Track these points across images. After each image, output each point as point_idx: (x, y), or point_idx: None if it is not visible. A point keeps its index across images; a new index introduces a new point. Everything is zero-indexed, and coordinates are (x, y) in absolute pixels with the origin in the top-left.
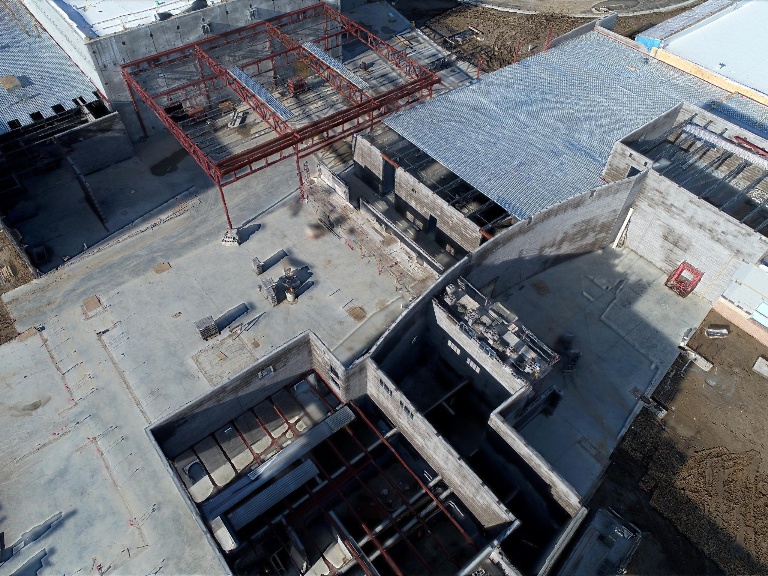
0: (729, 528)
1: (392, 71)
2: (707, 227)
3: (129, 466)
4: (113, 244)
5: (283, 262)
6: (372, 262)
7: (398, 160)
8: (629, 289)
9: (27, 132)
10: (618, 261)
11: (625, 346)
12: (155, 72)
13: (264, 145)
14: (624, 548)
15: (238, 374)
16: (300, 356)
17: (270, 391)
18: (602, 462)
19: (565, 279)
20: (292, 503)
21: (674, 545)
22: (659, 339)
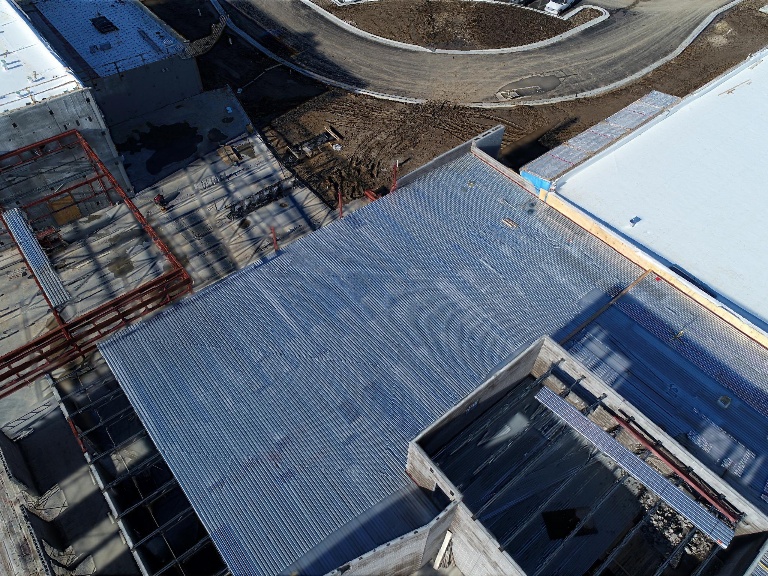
0: None
1: (199, 207)
2: None
3: None
4: None
5: None
6: None
7: None
8: None
9: None
10: None
11: None
12: None
13: None
14: None
15: None
16: None
17: None
18: None
19: None
20: None
21: None
22: None
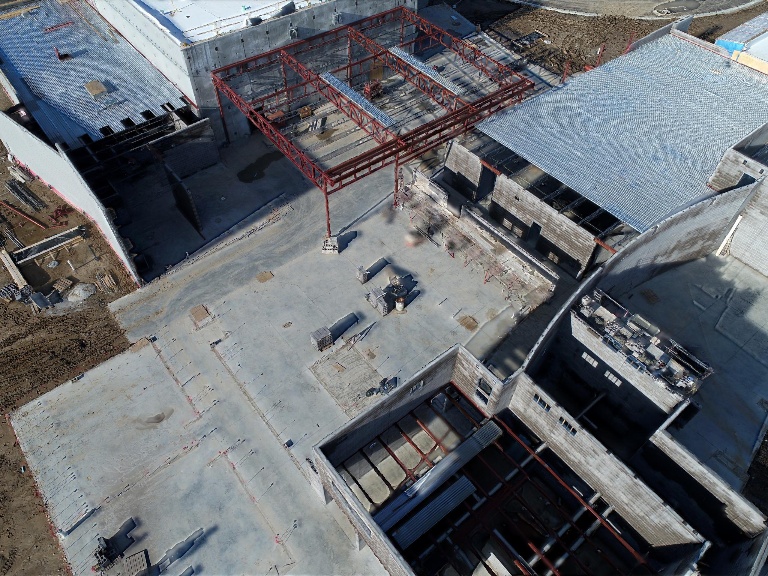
0: None
1: (464, 75)
2: None
3: (263, 481)
4: (212, 252)
5: (387, 271)
6: (478, 271)
7: (496, 167)
8: (739, 298)
9: (118, 139)
10: (723, 269)
11: (745, 356)
12: (242, 77)
13: (370, 152)
14: None
15: (396, 390)
16: (445, 370)
17: (413, 405)
18: (741, 476)
19: (673, 288)
20: (454, 521)
21: None
22: None
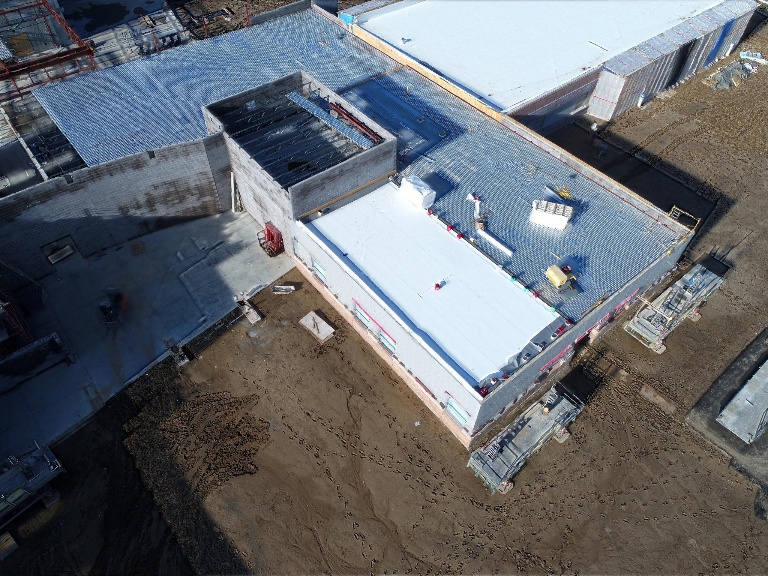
0: (186, 464)
1: (119, 49)
2: (264, 186)
3: None
4: None
5: None
6: None
7: None
8: (224, 249)
9: None
10: (230, 224)
11: (186, 301)
12: None
13: None
14: None
15: None
16: None
17: None
18: (95, 405)
19: (167, 240)
20: None
21: (122, 479)
22: (224, 295)
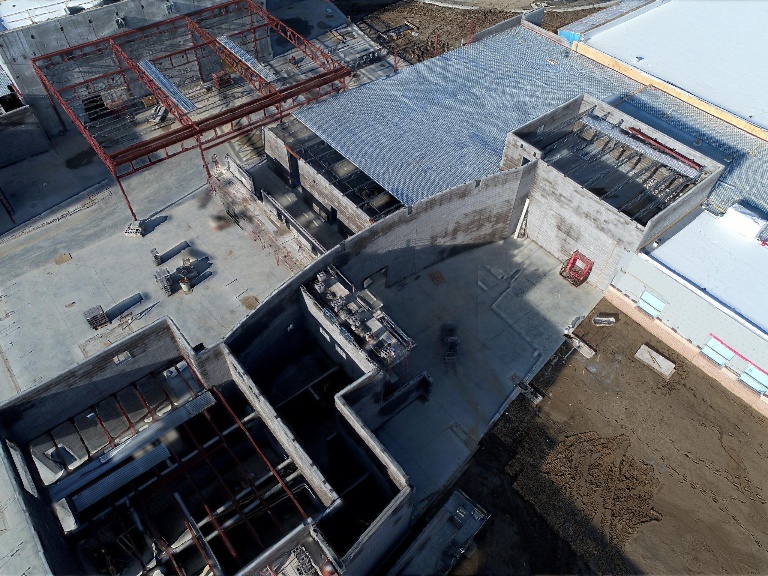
0: (587, 510)
1: None
2: (592, 216)
3: None
4: (17, 236)
5: (183, 253)
6: (270, 253)
7: (303, 152)
8: (524, 278)
9: None
10: (517, 251)
11: (511, 334)
12: None
13: (161, 137)
14: (473, 529)
15: (88, 359)
16: (162, 342)
17: (133, 377)
18: (470, 447)
19: (462, 269)
20: (139, 485)
21: (530, 527)
22: (546, 327)
